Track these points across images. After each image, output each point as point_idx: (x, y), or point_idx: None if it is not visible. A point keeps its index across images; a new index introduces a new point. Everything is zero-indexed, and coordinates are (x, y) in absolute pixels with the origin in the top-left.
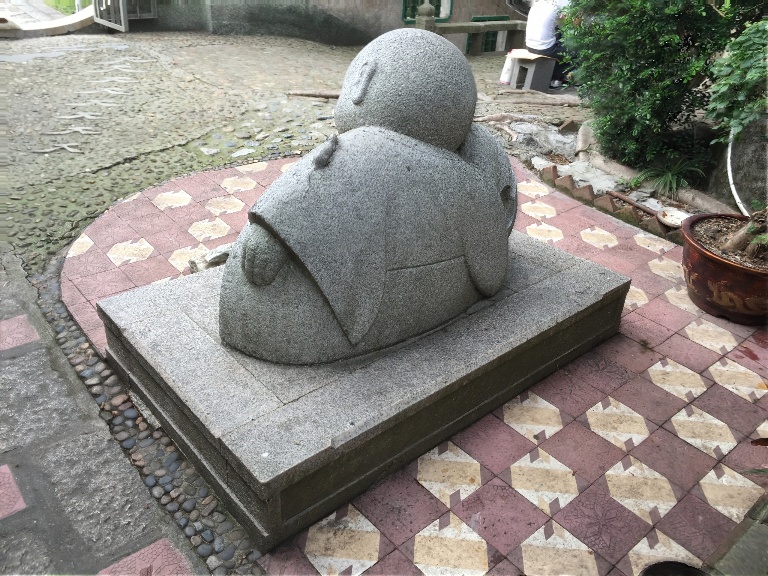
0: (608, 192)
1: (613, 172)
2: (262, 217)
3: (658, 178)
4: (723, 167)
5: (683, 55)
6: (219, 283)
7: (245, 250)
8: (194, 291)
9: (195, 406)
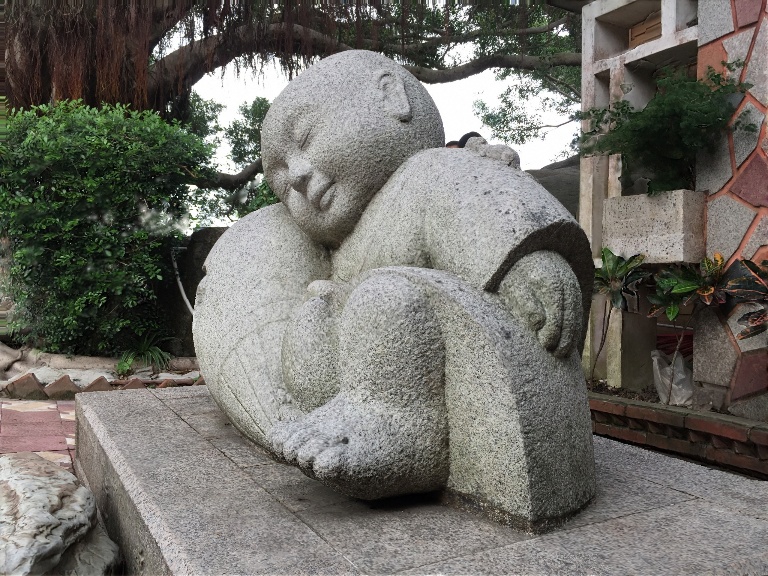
0: (112, 383)
1: (90, 366)
2: (576, 223)
3: (143, 356)
4: (189, 330)
5: (165, 216)
6: (266, 533)
7: (563, 292)
8: (290, 560)
9: (761, 562)
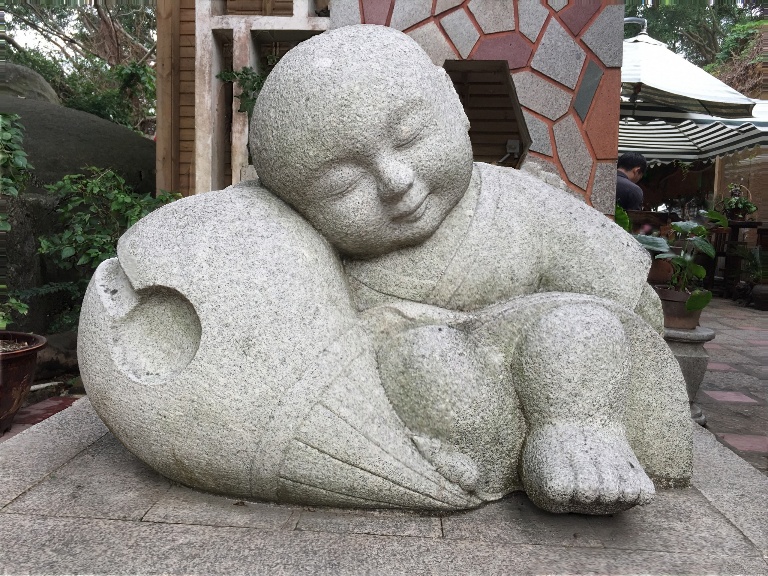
0: None
1: None
2: None
3: None
4: None
5: None
6: (662, 571)
7: None
8: (728, 575)
9: None
